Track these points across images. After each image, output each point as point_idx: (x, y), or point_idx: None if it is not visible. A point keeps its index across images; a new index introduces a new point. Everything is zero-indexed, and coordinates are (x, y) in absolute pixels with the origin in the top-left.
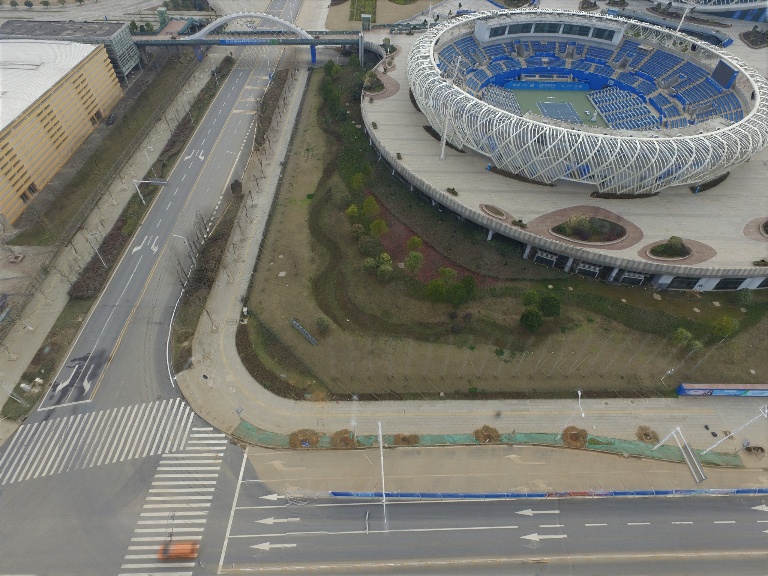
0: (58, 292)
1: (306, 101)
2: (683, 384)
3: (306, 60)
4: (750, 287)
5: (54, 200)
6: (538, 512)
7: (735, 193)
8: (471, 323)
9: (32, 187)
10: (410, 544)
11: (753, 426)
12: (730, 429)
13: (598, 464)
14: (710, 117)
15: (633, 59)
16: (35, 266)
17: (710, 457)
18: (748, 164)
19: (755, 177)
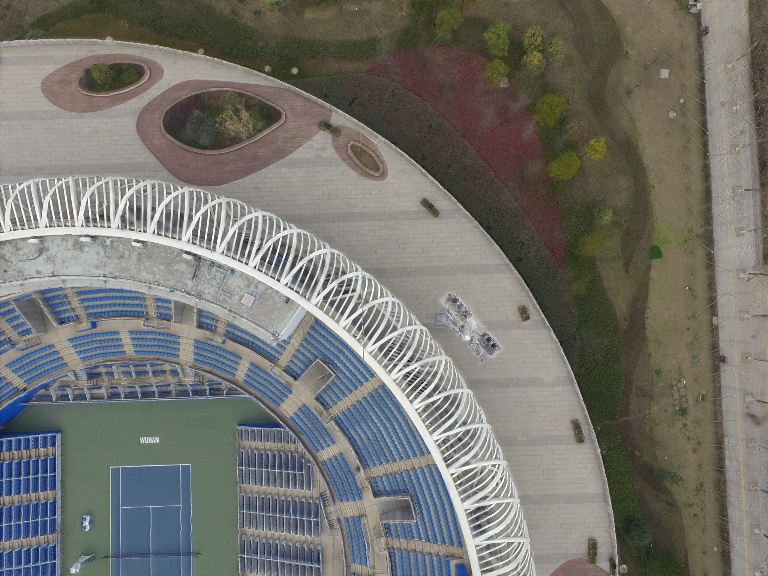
0: None
1: None
2: None
3: None
4: None
5: None
6: None
7: None
8: None
9: None
10: None
11: None
12: None
13: None
14: None
15: None
16: None
17: None
18: None
19: None
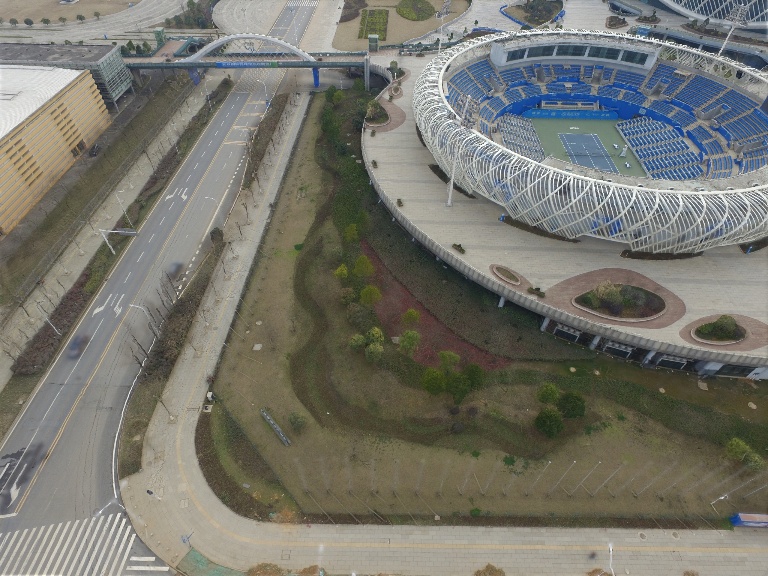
0: (2, 365)
1: (304, 130)
2: (740, 514)
3: (309, 83)
4: None
5: (20, 246)
6: None
7: None
8: (476, 420)
9: None
10: None
11: None
12: None
13: None
14: (761, 157)
15: (668, 85)
16: None
17: None
18: None
19: None
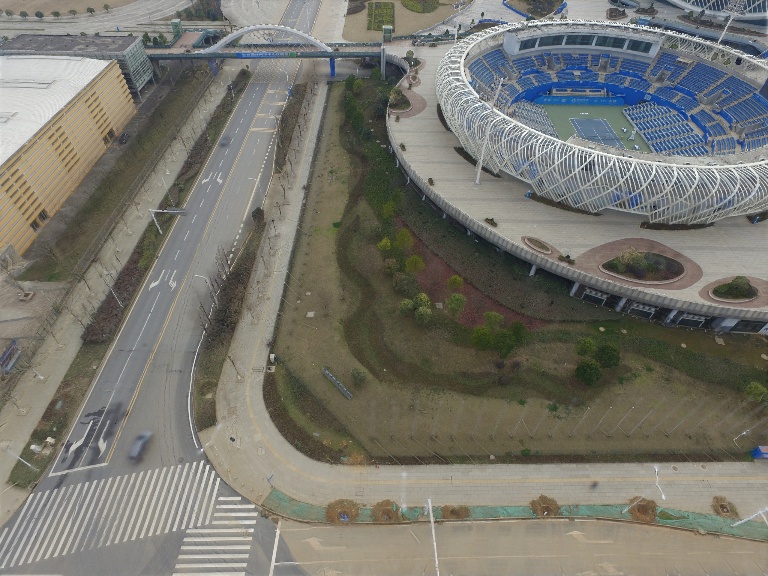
0: (71, 335)
1: (327, 118)
2: (760, 447)
3: (325, 73)
4: None
5: (66, 228)
6: None
7: None
8: (519, 373)
9: (43, 214)
10: None
11: None
12: None
13: (672, 543)
14: (761, 137)
15: (671, 73)
16: (46, 305)
17: None
18: None
19: None
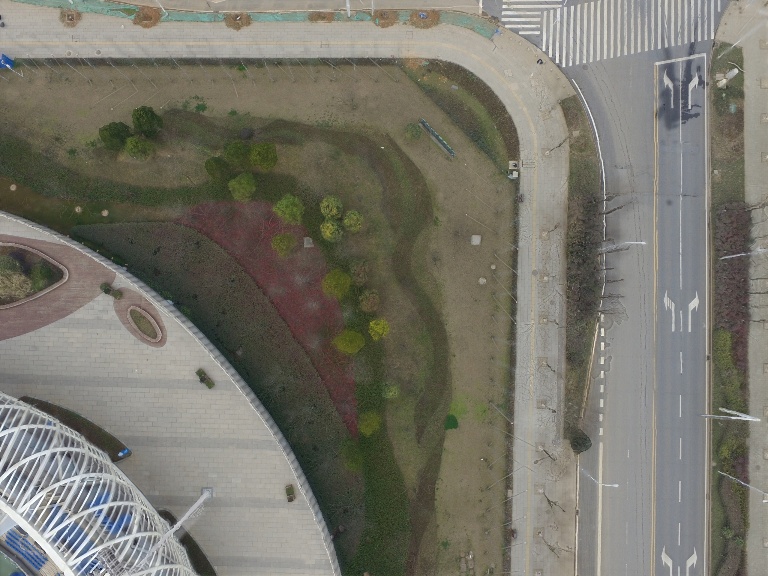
0: None
1: None
2: None
3: None
4: None
5: None
6: None
7: None
8: None
9: None
10: None
11: None
12: None
13: None
14: None
15: None
16: None
17: None
18: None
19: None
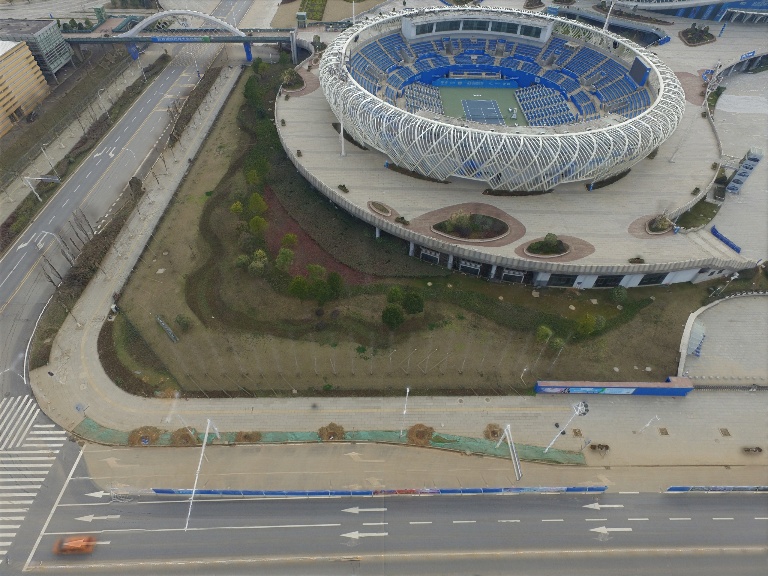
0: None
1: (231, 99)
2: (538, 382)
3: (242, 58)
4: (631, 284)
5: None
6: (364, 510)
7: (630, 190)
8: (338, 320)
9: None
10: (226, 542)
11: (605, 424)
12: (580, 427)
13: (438, 462)
14: (621, 114)
15: (560, 56)
16: None
17: (553, 455)
18: (652, 161)
19: (655, 174)
